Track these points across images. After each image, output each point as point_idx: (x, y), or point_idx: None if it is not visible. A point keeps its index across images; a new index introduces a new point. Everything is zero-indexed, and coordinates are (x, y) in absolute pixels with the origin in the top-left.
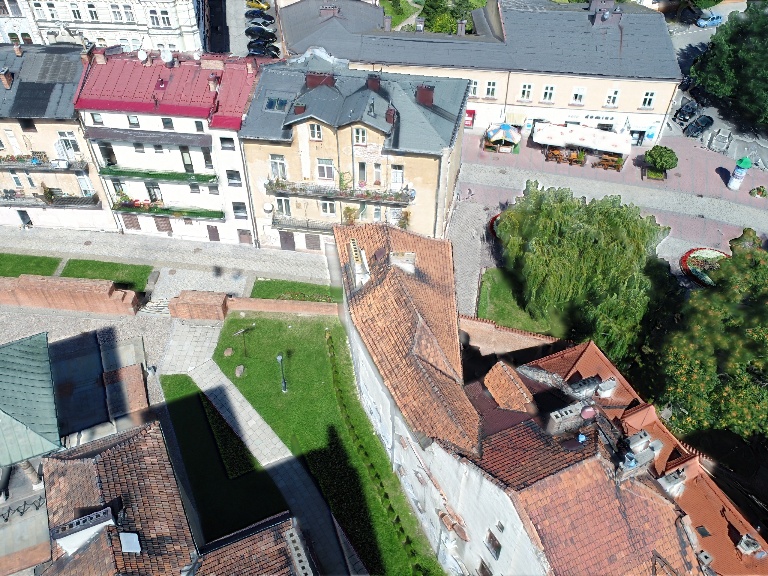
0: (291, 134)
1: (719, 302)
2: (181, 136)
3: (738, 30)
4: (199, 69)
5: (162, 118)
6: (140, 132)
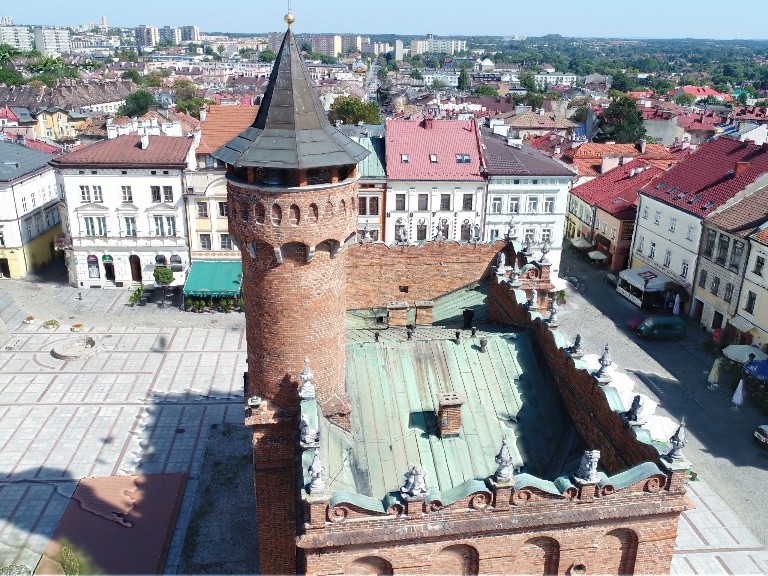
0: (37, 119)
1: None
2: None
3: None
4: None
5: None
6: None
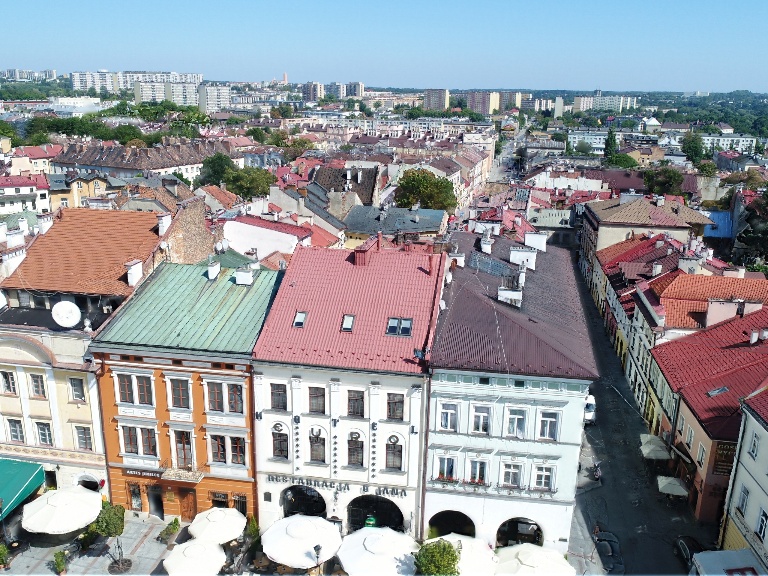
0: (71, 187)
1: (228, 184)
2: (24, 195)
3: (201, 180)
4: (20, 176)
5: (15, 189)
6: (5, 196)
